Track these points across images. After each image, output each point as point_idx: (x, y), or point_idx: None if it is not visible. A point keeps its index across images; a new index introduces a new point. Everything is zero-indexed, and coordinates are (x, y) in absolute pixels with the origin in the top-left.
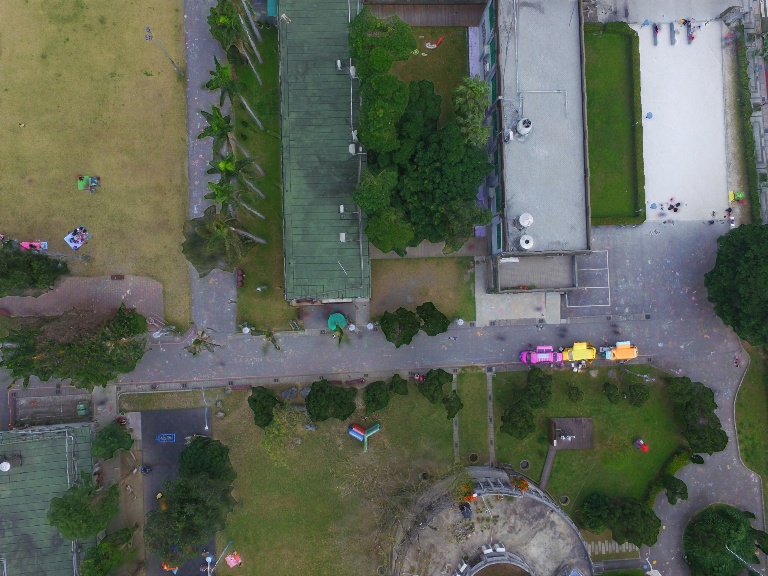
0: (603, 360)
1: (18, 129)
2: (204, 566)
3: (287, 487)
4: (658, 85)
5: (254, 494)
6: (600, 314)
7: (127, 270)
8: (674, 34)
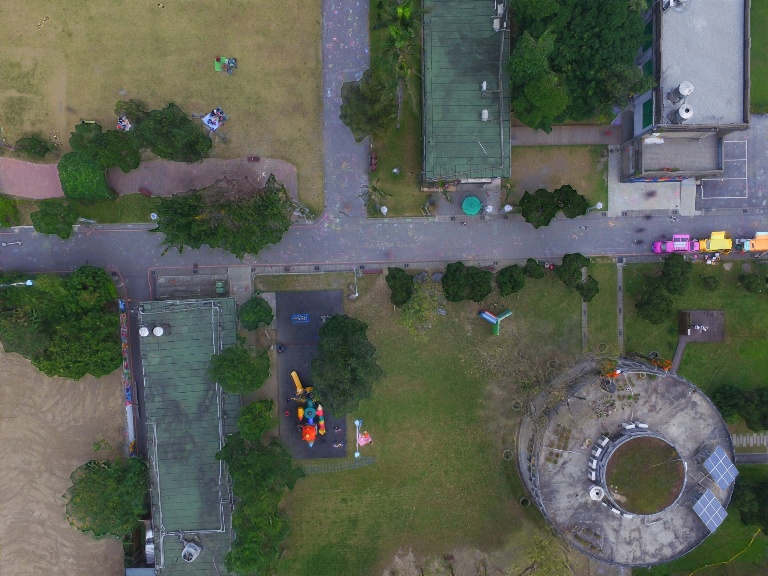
0: (737, 253)
1: (157, 9)
2: (336, 442)
3: (416, 370)
4: None
5: (384, 376)
6: (736, 206)
7: (262, 152)
8: None
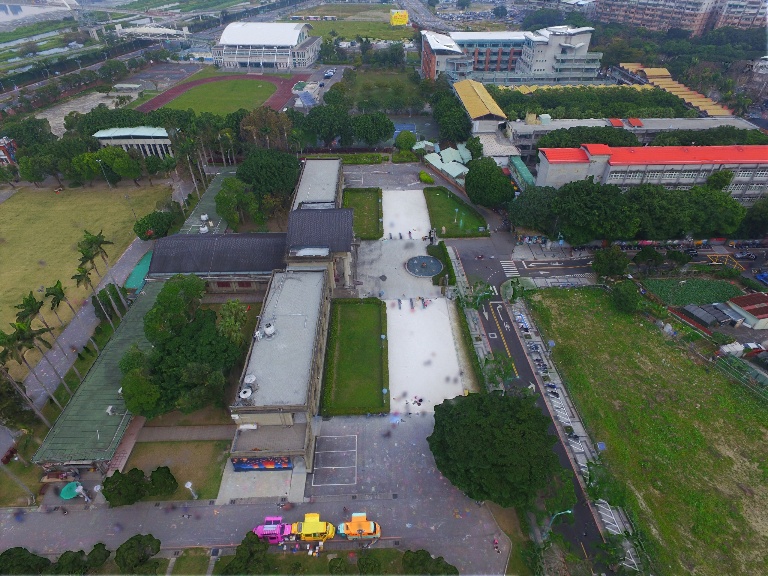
0: (344, 542)
1: None
2: None
3: None
4: (403, 329)
5: None
6: (345, 493)
7: None
8: (412, 303)
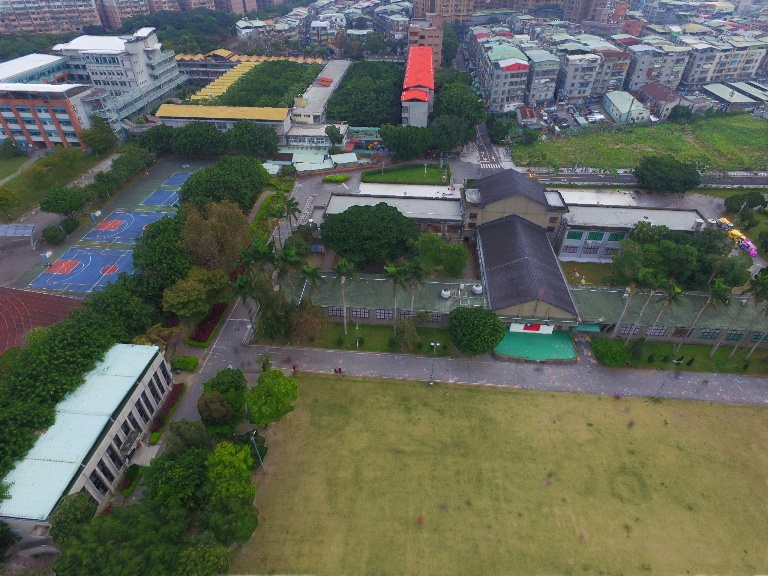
0: None
1: None
2: None
3: None
4: None
5: None
6: None
7: None
8: None
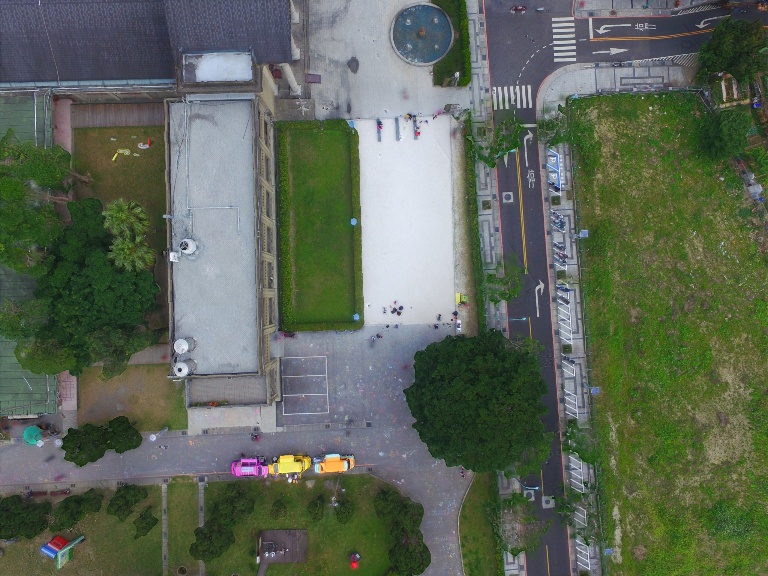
0: None
1: None
2: None
3: None
4: (383, 183)
5: None
6: (318, 422)
7: None
8: (398, 130)
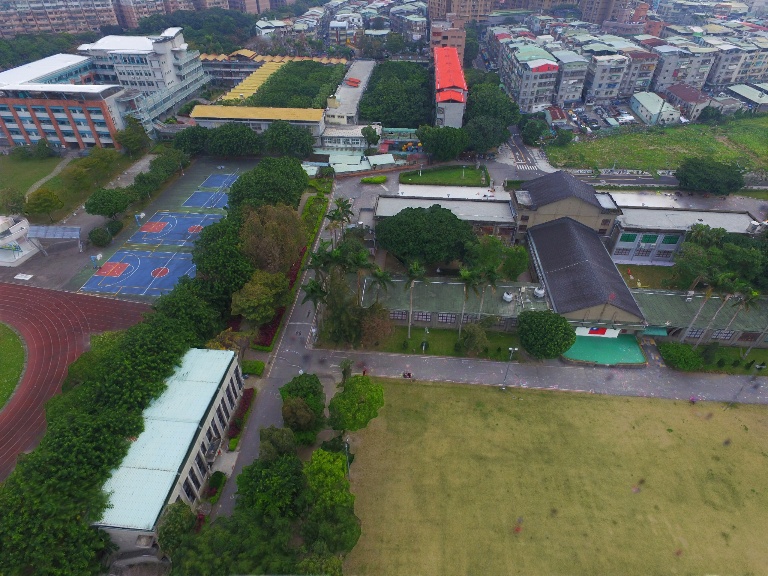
0: None
1: None
2: None
3: None
4: None
5: None
6: None
7: None
8: None
